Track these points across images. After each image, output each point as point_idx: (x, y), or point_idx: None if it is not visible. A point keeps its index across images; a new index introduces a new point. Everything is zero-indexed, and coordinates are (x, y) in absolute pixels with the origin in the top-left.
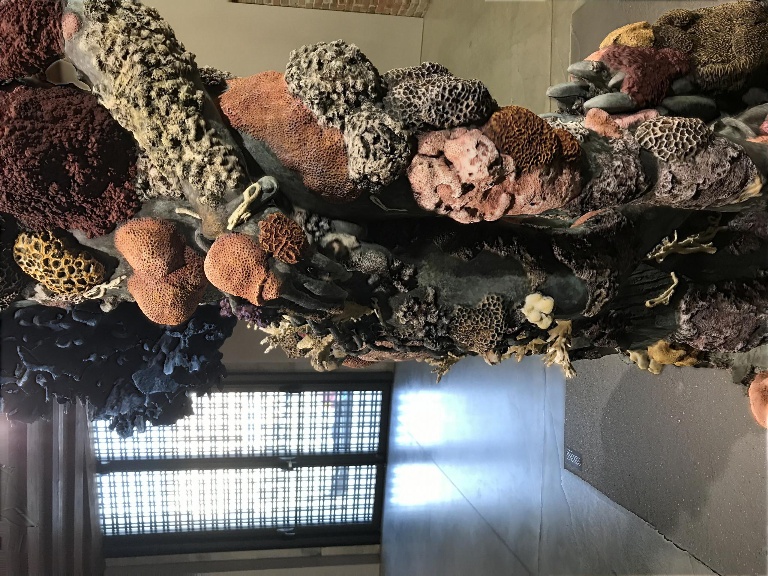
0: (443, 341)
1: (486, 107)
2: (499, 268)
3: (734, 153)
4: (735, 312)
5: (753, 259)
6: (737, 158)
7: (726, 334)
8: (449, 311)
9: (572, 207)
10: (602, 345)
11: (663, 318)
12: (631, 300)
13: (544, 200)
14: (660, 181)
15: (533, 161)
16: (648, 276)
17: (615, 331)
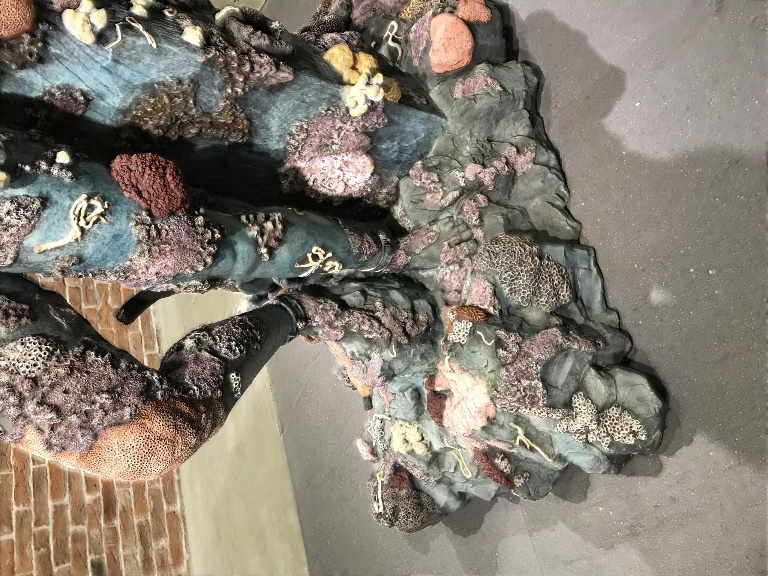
0: None
1: None
2: None
3: None
4: None
5: None
6: None
7: None
8: None
9: None
10: None
11: None
12: None
13: None
14: None
15: None
16: None
17: None
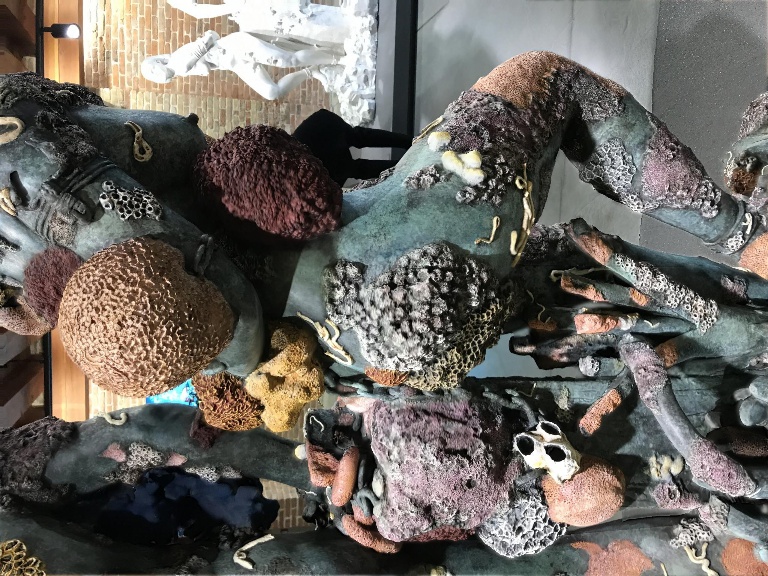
0: None
1: None
2: None
3: None
4: None
5: None
6: None
7: None
8: None
9: None
10: None
11: None
12: None
13: None
14: None
15: None
16: None
17: None
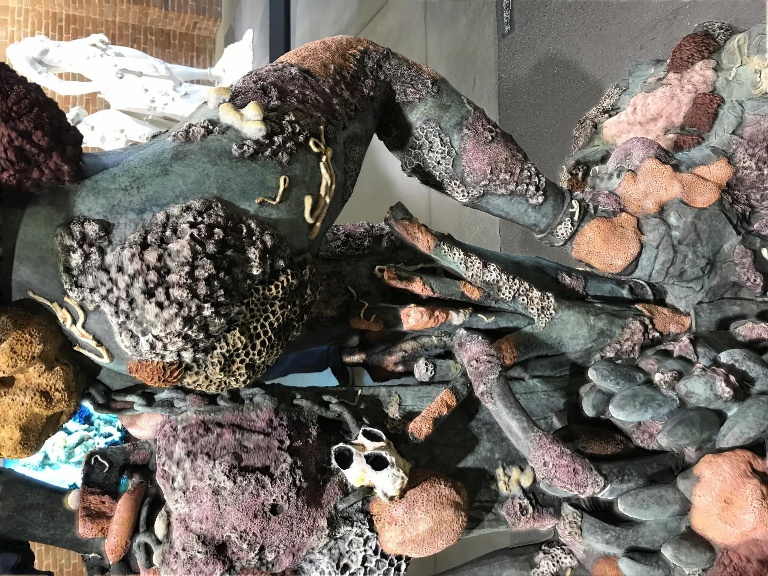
0: None
1: None
2: None
3: None
4: None
5: None
6: None
7: None
8: None
9: None
10: None
11: None
12: None
13: None
14: None
15: None
16: None
17: None
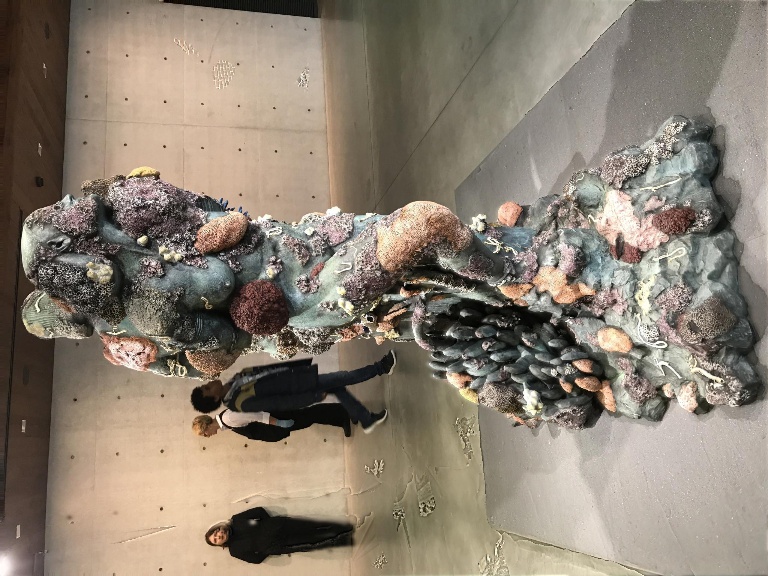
0: None
1: None
2: None
3: None
4: None
5: None
6: None
7: None
8: None
9: None
10: None
11: None
12: None
13: None
14: None
15: None
16: None
17: None
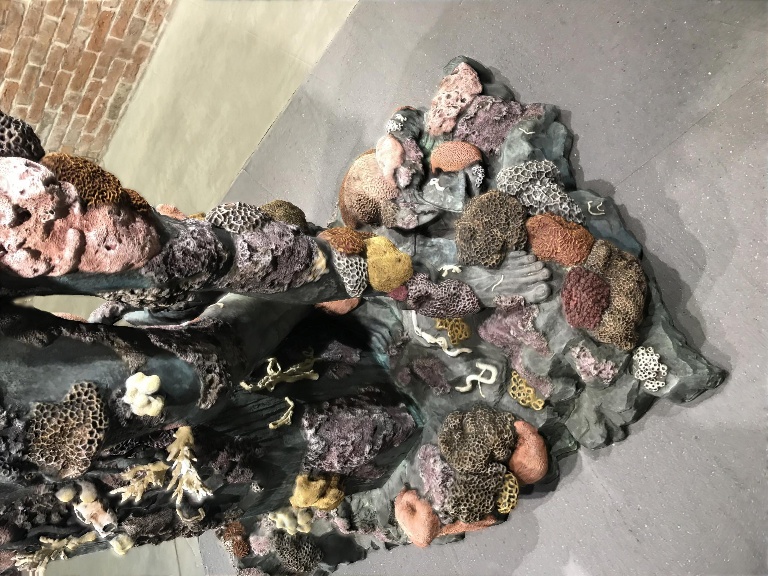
0: (21, 469)
1: (34, 145)
2: (86, 355)
3: (293, 227)
4: (352, 418)
5: (352, 381)
6: (297, 232)
7: (352, 439)
8: (23, 412)
9: (156, 267)
10: (236, 477)
11: (290, 437)
12: (254, 425)
13: (120, 243)
14: (238, 252)
15: (98, 195)
16: (264, 403)
17: (246, 457)
